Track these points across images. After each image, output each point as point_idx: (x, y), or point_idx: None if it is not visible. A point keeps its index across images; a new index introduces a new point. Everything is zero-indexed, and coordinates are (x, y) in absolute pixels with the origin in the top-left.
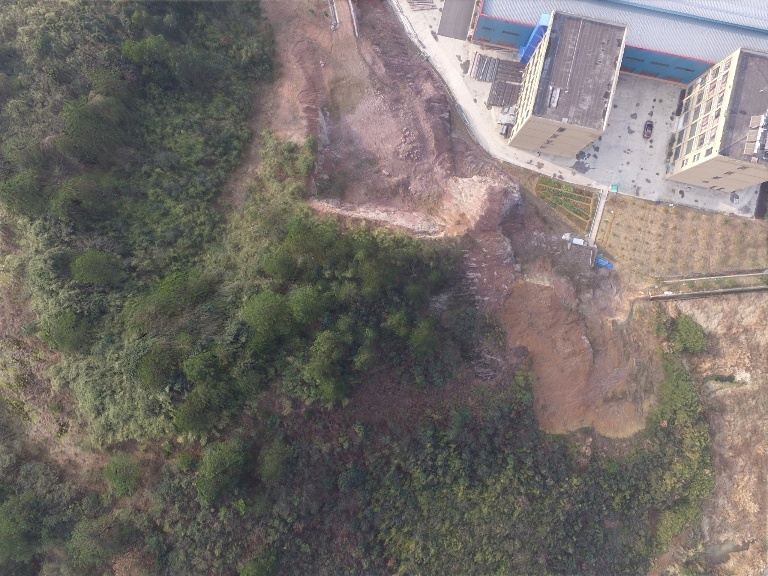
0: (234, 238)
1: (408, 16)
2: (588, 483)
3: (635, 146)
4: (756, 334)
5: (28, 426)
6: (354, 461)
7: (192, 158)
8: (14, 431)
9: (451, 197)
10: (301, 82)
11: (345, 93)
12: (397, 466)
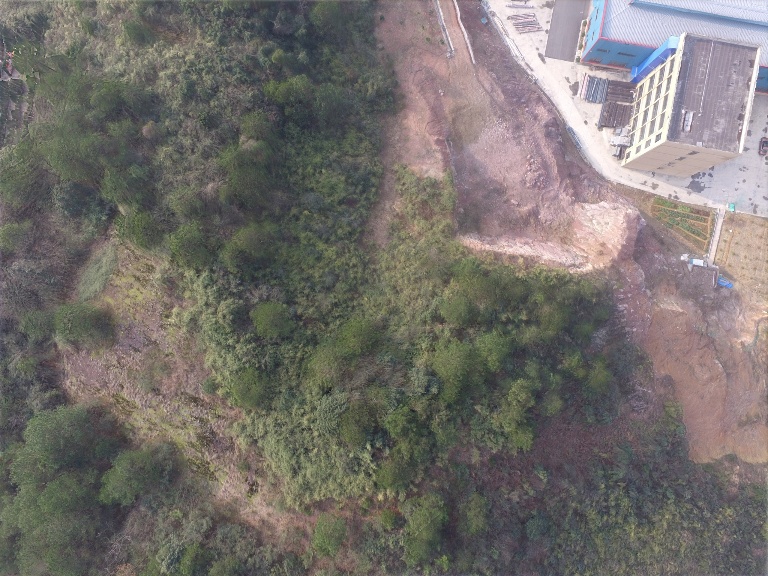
0: (389, 280)
1: (514, 39)
2: (738, 512)
3: (750, 163)
4: None
5: (215, 486)
6: (538, 507)
7: (334, 198)
8: (199, 491)
9: (581, 225)
10: (425, 113)
11: (467, 122)
12: (574, 509)
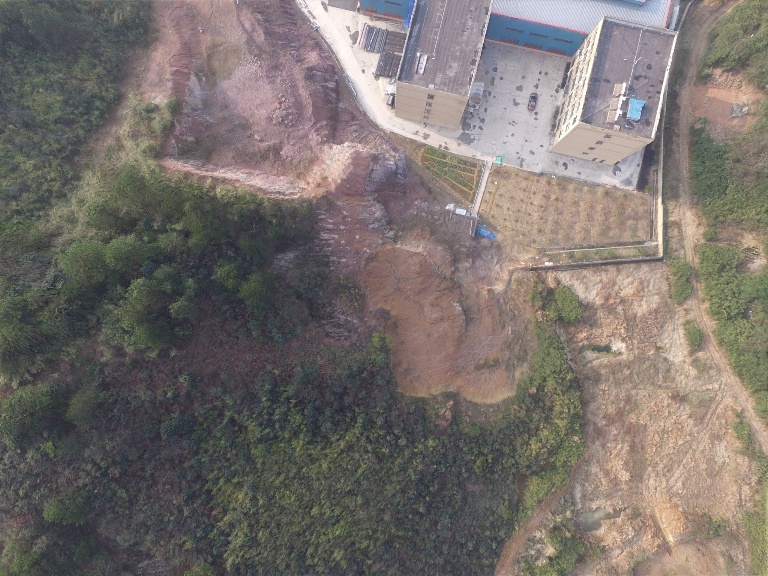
0: (82, 194)
1: None
2: (447, 445)
3: (520, 118)
4: (633, 305)
5: None
6: (181, 411)
7: (50, 116)
8: None
9: (323, 163)
10: (175, 47)
11: (222, 59)
12: (230, 418)
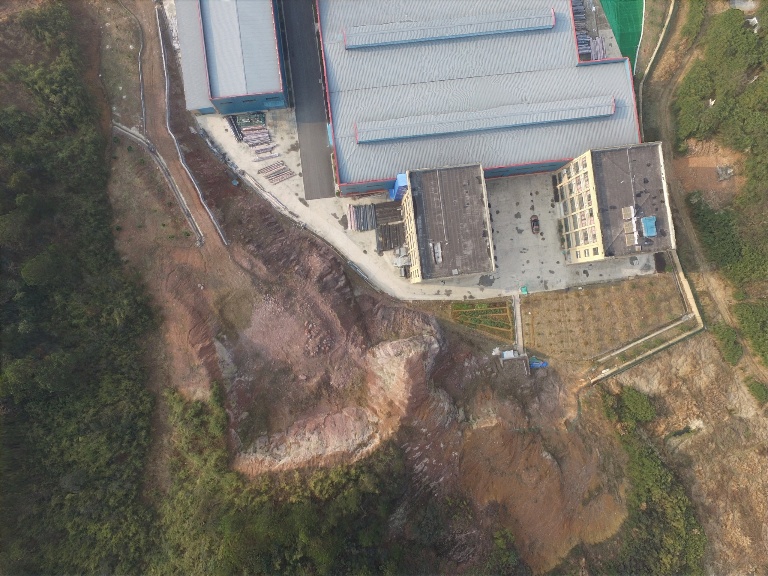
0: (173, 538)
1: (271, 191)
2: None
3: (529, 243)
4: (695, 380)
5: None
6: None
7: (100, 462)
8: None
9: (374, 376)
10: (186, 319)
11: (235, 309)
12: None
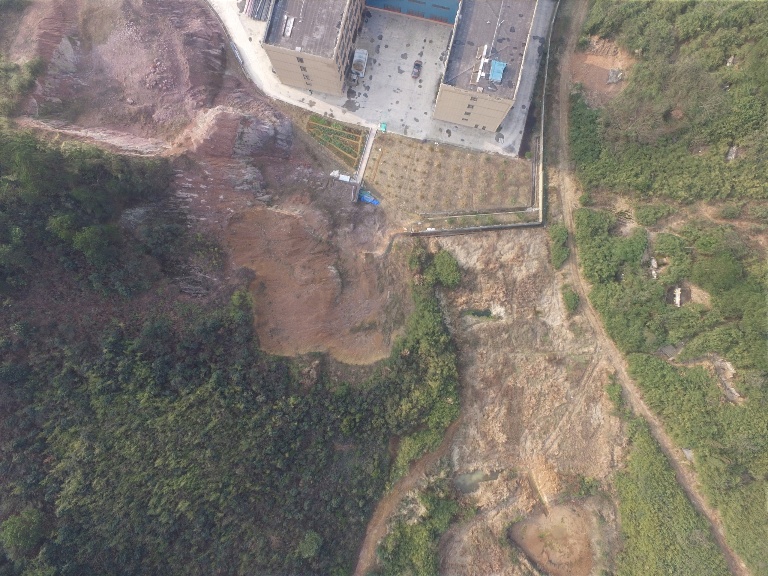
0: None
1: None
2: (311, 404)
3: (405, 86)
4: (513, 270)
5: None
6: (13, 360)
7: None
8: None
9: (195, 126)
10: (47, 10)
11: (98, 23)
12: (69, 369)
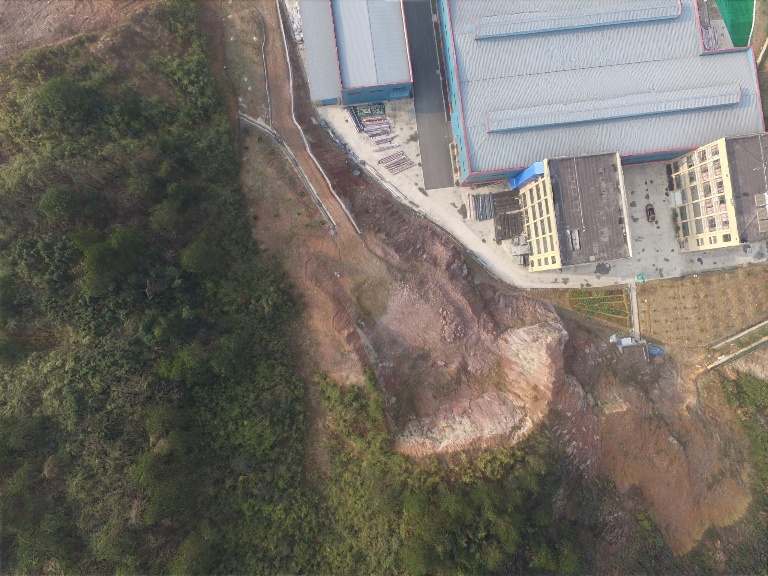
0: (344, 518)
1: (391, 181)
2: None
3: (644, 232)
4: None
5: None
6: None
7: (265, 445)
8: None
9: (510, 362)
10: (328, 306)
11: (371, 296)
12: None
